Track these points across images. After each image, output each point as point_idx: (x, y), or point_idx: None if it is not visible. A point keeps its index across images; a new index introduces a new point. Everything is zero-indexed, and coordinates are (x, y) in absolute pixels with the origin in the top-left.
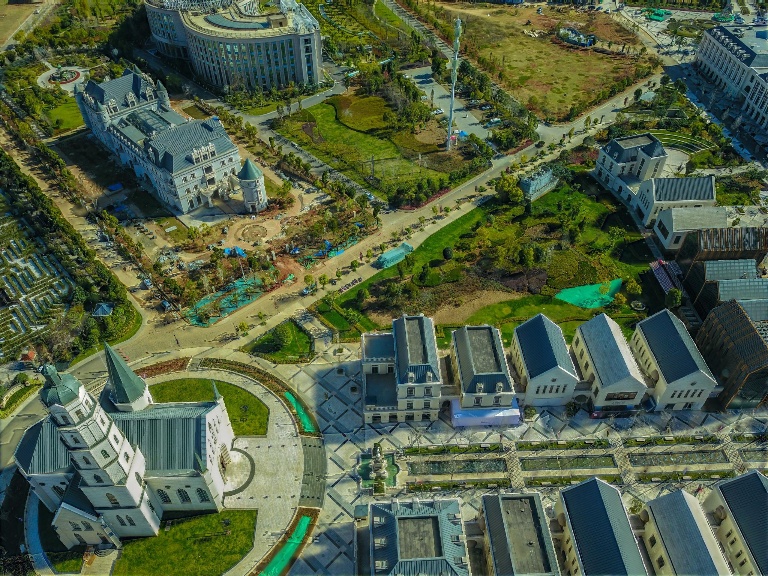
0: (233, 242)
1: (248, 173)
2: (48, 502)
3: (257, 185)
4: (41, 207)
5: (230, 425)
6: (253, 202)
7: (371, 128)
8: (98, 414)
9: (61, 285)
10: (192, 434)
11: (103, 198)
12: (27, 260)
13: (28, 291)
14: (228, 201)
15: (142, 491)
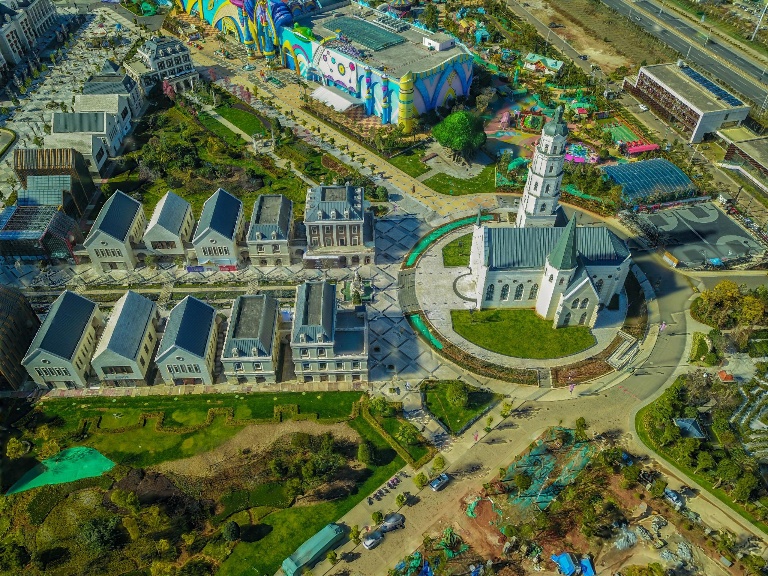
0: None
1: None
2: None
3: None
4: None
5: None
6: None
7: None
8: None
9: None
10: None
11: None
12: None
13: None
14: None
15: None
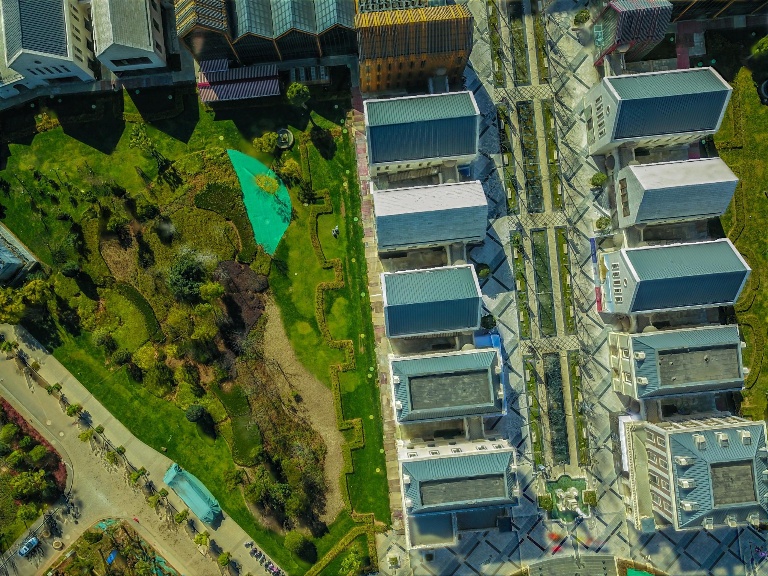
0: None
1: None
2: None
3: None
4: None
5: None
6: None
7: None
8: None
9: None
10: None
11: None
12: None
13: None
14: None
15: None
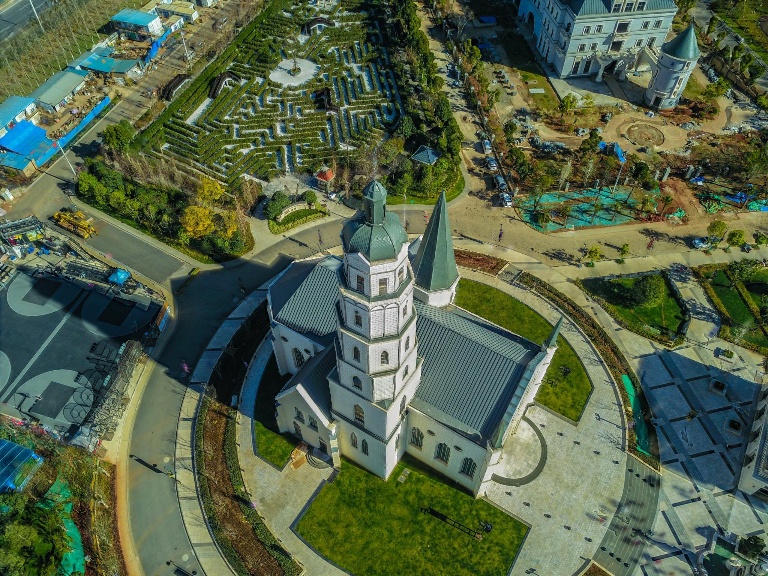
0: (612, 136)
1: (681, 47)
2: (281, 361)
3: (684, 69)
4: (401, 13)
5: (538, 385)
6: (662, 92)
7: None
8: (406, 297)
9: (389, 109)
10: (501, 383)
11: (469, 28)
12: (364, 68)
13: (352, 102)
14: (623, 81)
15: (398, 422)
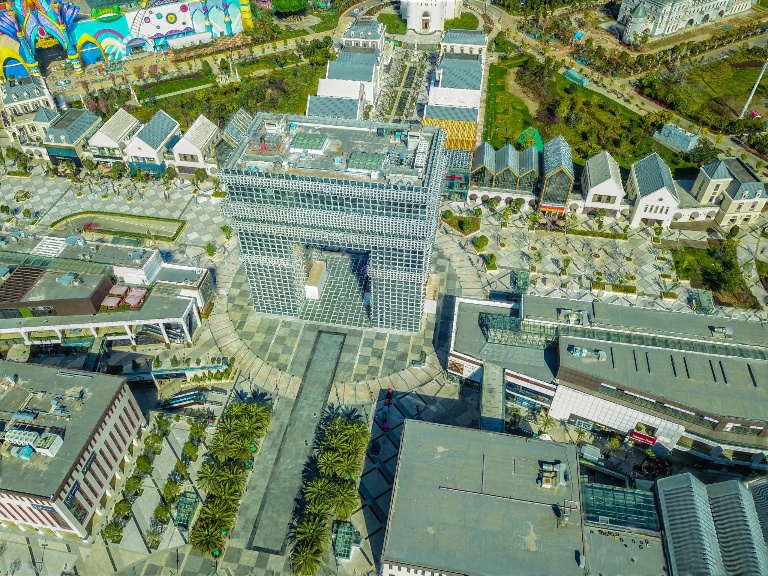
0: (589, 35)
1: (634, 9)
2: None
3: (630, 20)
4: None
5: (442, 20)
6: (624, 31)
7: (765, 85)
8: None
9: None
10: None
11: None
12: None
13: None
14: None
15: None
